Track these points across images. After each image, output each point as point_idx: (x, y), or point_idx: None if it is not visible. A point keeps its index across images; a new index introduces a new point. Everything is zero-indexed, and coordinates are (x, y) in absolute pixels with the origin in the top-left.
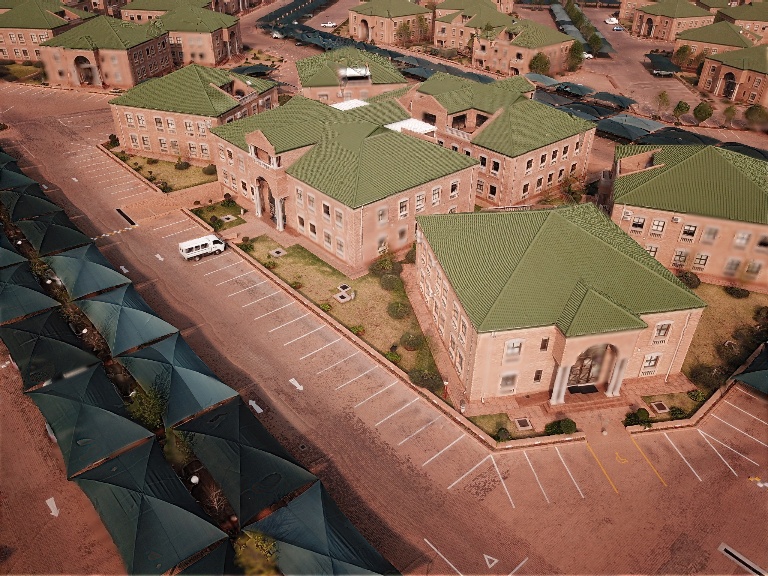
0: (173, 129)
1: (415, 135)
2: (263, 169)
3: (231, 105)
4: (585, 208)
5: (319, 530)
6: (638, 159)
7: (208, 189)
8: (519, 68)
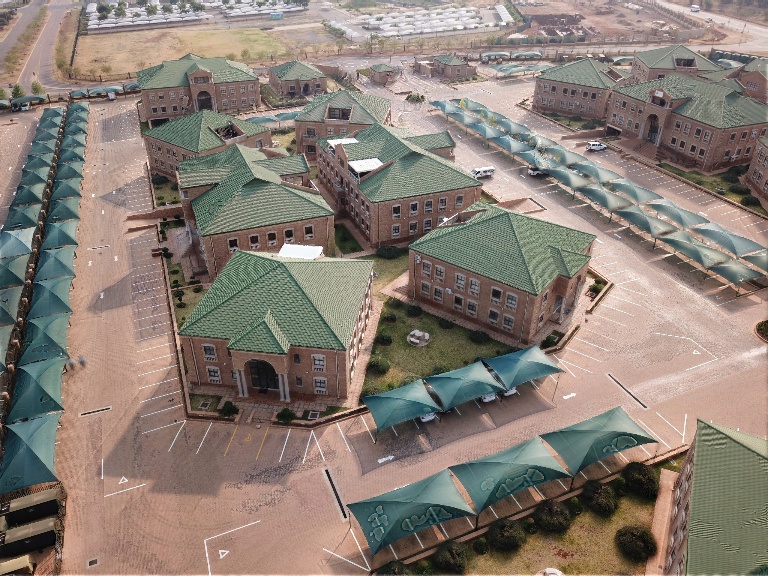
0: None
1: None
2: None
3: (466, 210)
4: None
5: (447, 105)
6: None
7: None
8: None
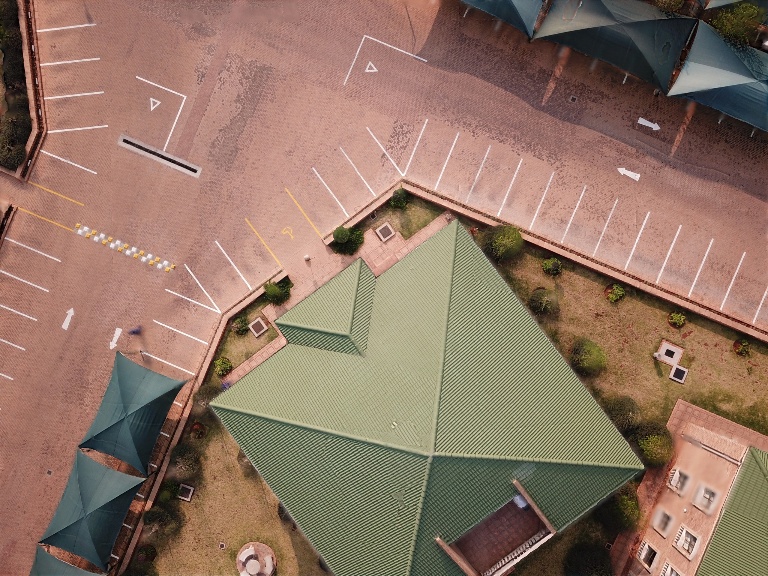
0: None
1: None
2: None
3: None
4: None
5: None
6: None
7: None
8: None
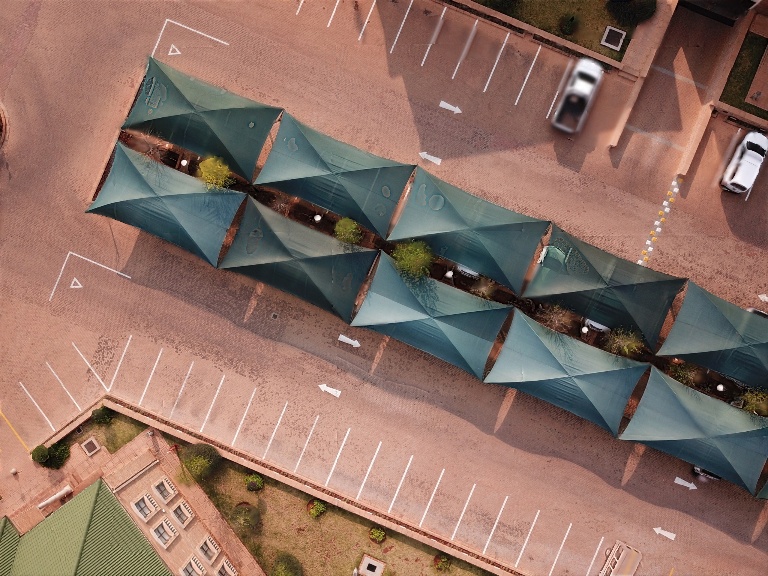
0: None
1: None
2: None
3: None
4: None
5: (180, 214)
6: None
7: None
8: None
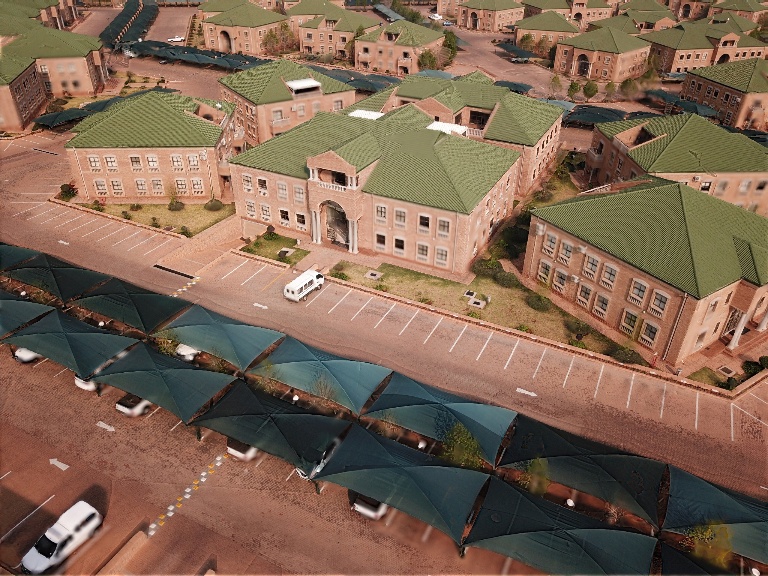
0: (155, 167)
1: None
2: (334, 192)
3: (217, 132)
4: None
5: (731, 504)
6: (630, 133)
7: (230, 226)
8: (408, 66)
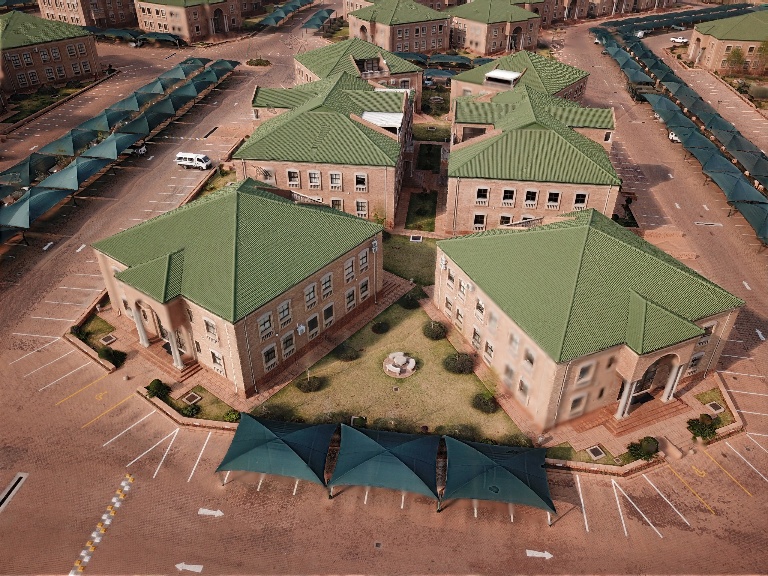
0: None
1: (368, 125)
2: None
3: None
4: (337, 219)
5: None
6: None
7: None
8: None
